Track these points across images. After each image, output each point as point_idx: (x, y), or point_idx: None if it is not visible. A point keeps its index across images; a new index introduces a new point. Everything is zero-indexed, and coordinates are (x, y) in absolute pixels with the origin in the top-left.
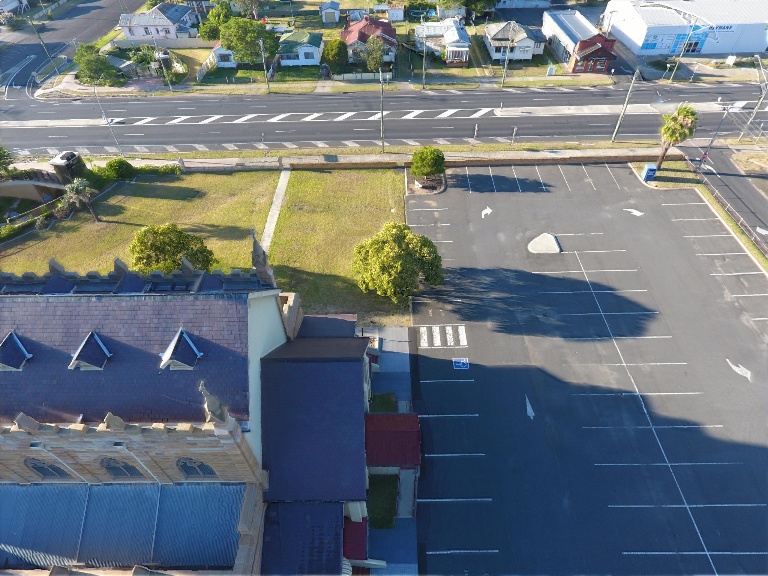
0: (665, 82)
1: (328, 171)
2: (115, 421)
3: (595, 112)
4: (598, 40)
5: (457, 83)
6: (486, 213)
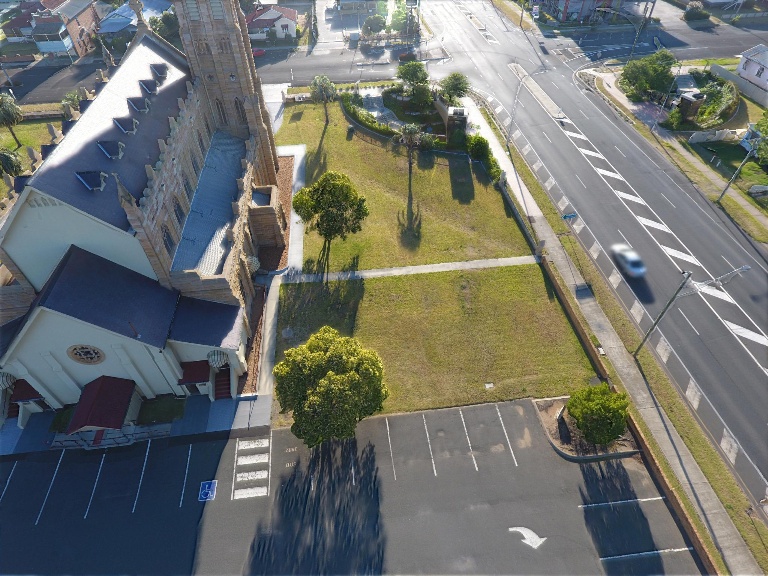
0: None
1: (554, 298)
2: (7, 180)
3: None
4: None
5: None
6: (525, 535)
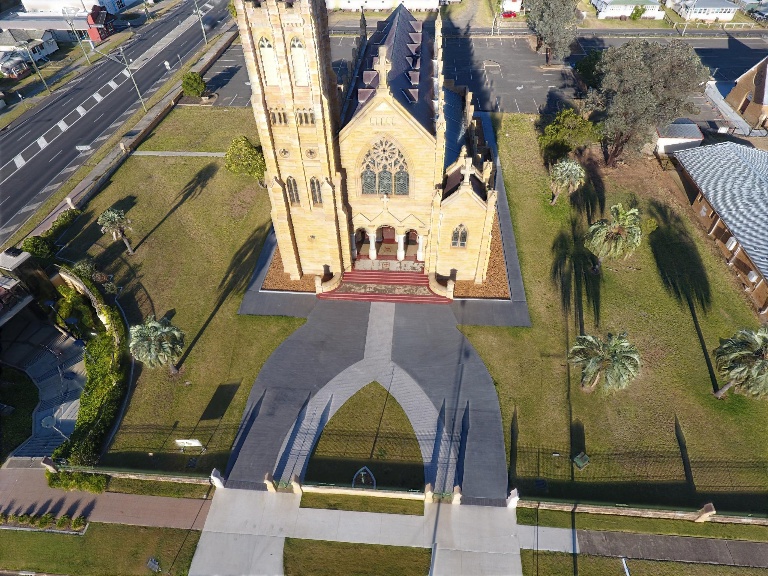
0: (151, 21)
1: (152, 134)
2: None
3: (169, 41)
4: (97, 10)
5: (61, 78)
6: None
